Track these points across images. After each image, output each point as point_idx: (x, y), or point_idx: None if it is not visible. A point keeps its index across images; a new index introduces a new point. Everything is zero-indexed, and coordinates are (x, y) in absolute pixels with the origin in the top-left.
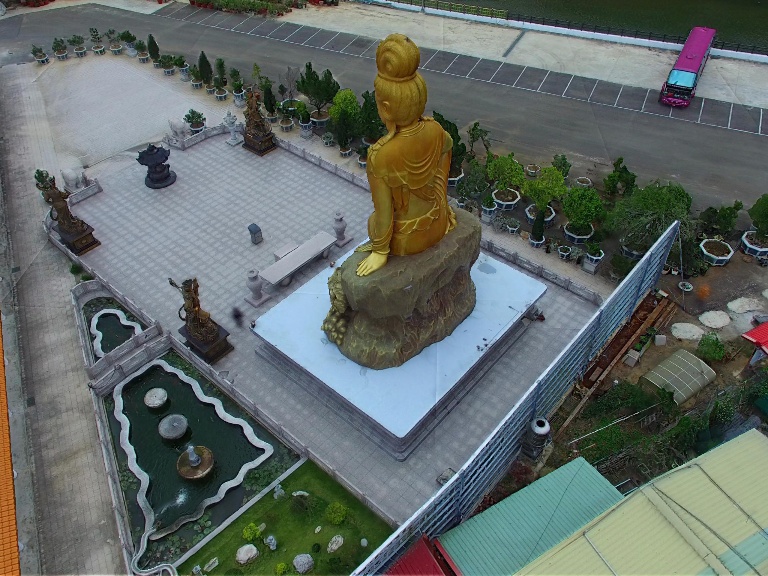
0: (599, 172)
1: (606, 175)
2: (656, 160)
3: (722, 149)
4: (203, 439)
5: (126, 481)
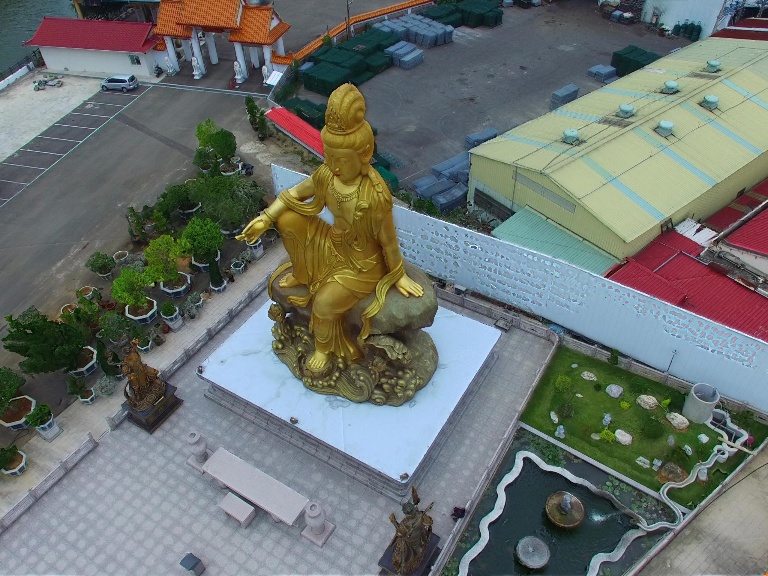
0: (99, 250)
1: (106, 245)
2: (89, 213)
3: (84, 176)
4: (527, 529)
5: None
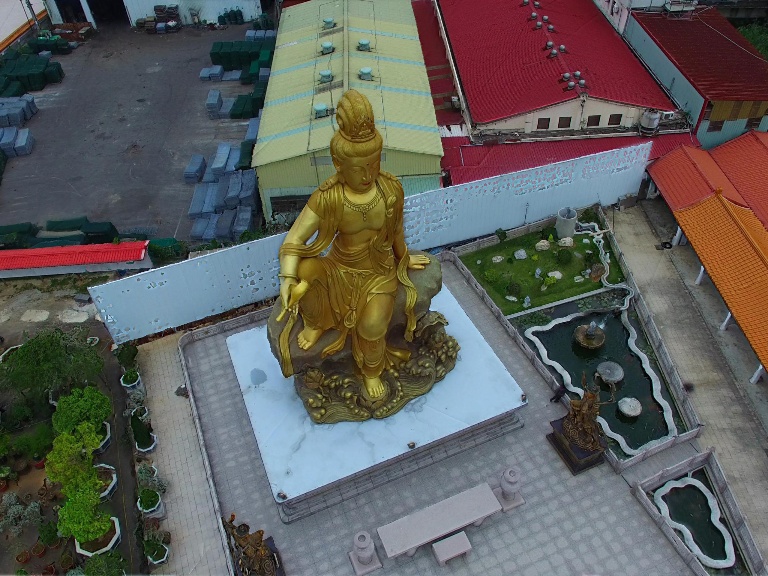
0: None
1: None
2: None
3: None
4: (584, 368)
5: (649, 351)
